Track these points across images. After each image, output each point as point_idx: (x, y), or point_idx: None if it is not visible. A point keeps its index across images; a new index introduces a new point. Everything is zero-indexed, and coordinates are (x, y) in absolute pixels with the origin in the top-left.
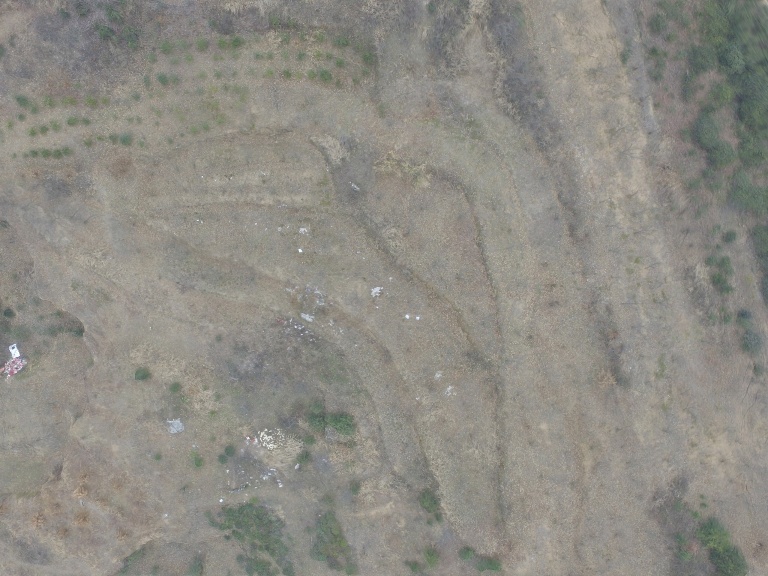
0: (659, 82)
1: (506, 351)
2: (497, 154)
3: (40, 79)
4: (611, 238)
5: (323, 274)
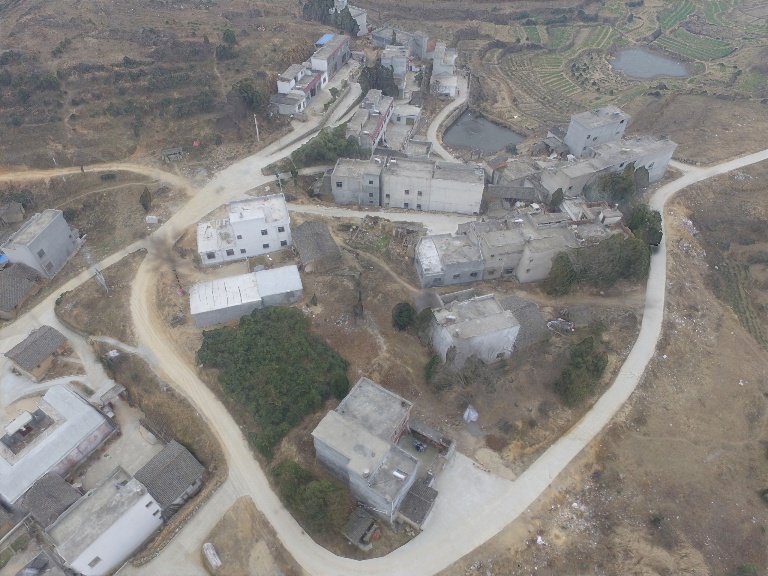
0: None
1: None
2: (55, 8)
3: None
4: (39, 0)
5: None
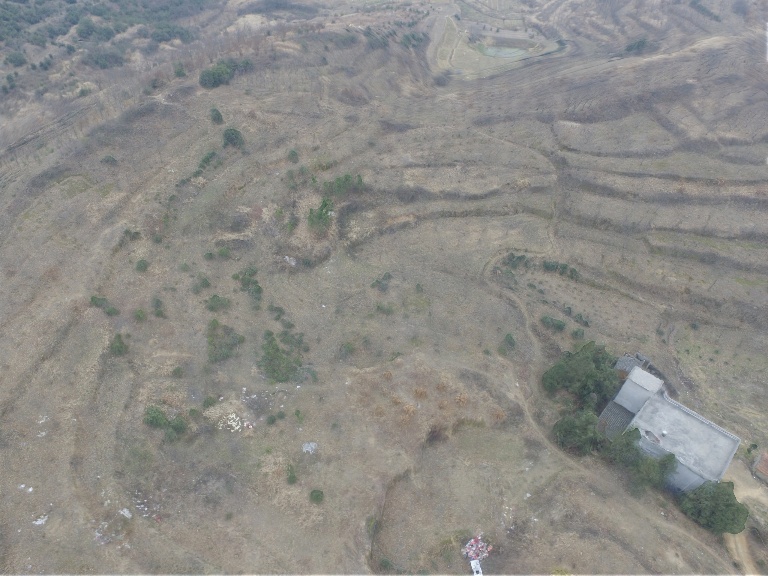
0: None
1: None
2: None
3: None
4: None
5: (80, 551)
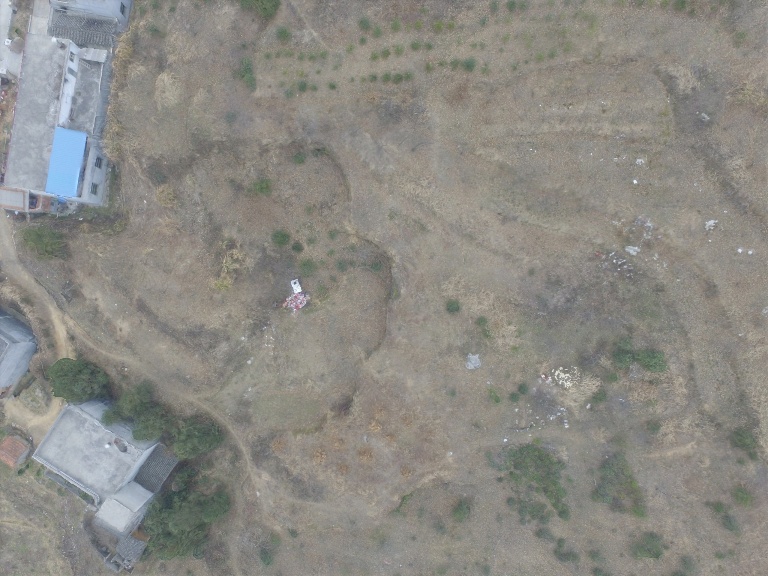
0: None
1: None
2: None
3: (384, 3)
4: None
5: (657, 206)
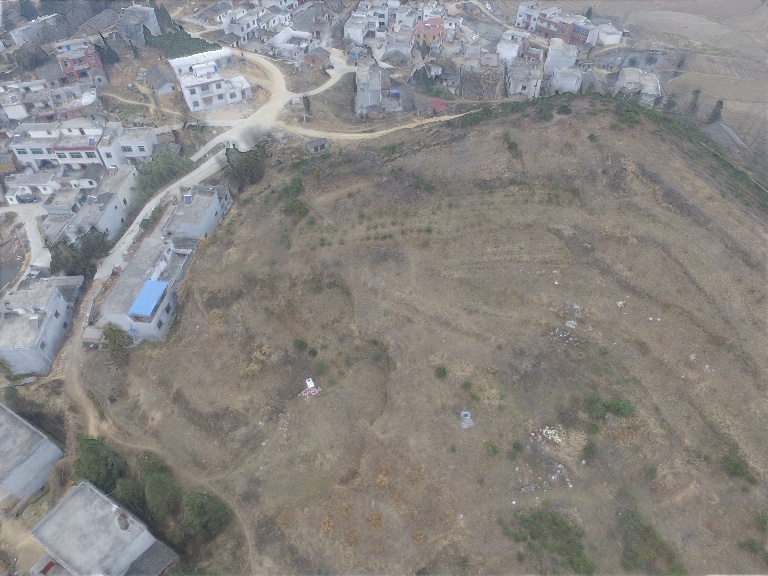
0: (750, 207)
1: (741, 334)
2: (673, 229)
3: (373, 208)
4: None
5: (577, 295)
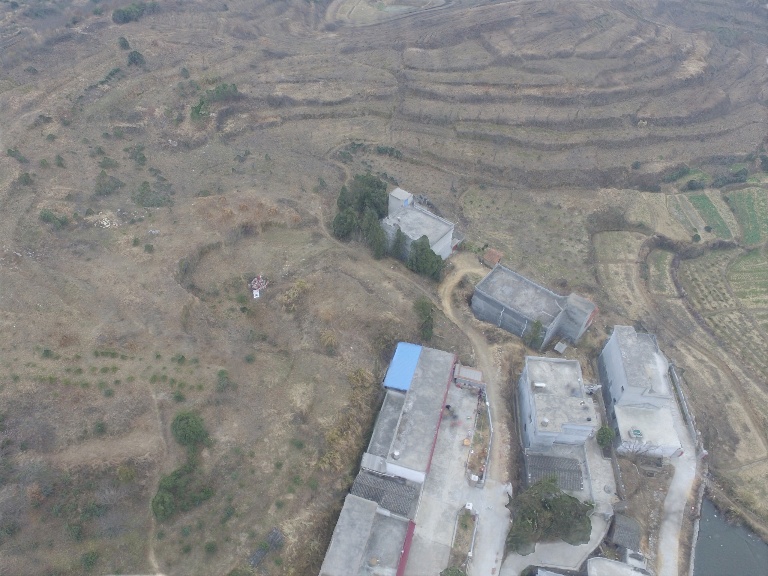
0: None
1: None
2: None
3: (84, 406)
4: None
5: None
